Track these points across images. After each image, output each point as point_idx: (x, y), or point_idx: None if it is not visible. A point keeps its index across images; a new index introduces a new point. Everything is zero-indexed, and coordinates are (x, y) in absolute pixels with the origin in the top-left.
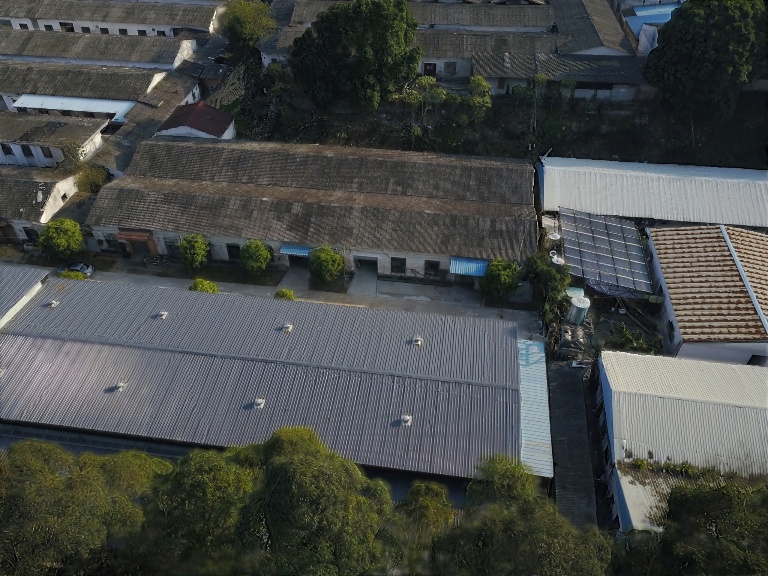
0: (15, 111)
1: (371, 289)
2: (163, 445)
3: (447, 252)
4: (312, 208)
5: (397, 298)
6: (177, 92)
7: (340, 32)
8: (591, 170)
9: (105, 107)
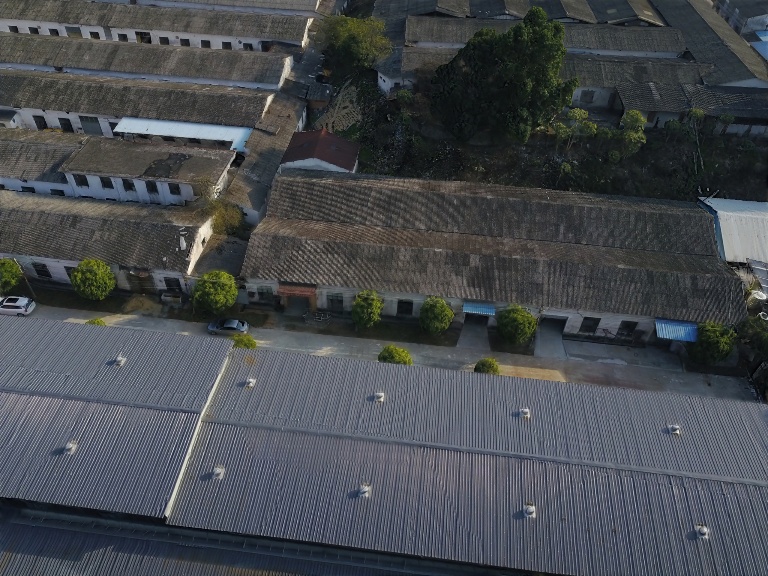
0: (110, 134)
1: (559, 350)
2: (424, 561)
3: (650, 313)
4: (492, 261)
5: (590, 361)
6: (290, 116)
7: (496, 62)
8: (767, 216)
9: (219, 134)
